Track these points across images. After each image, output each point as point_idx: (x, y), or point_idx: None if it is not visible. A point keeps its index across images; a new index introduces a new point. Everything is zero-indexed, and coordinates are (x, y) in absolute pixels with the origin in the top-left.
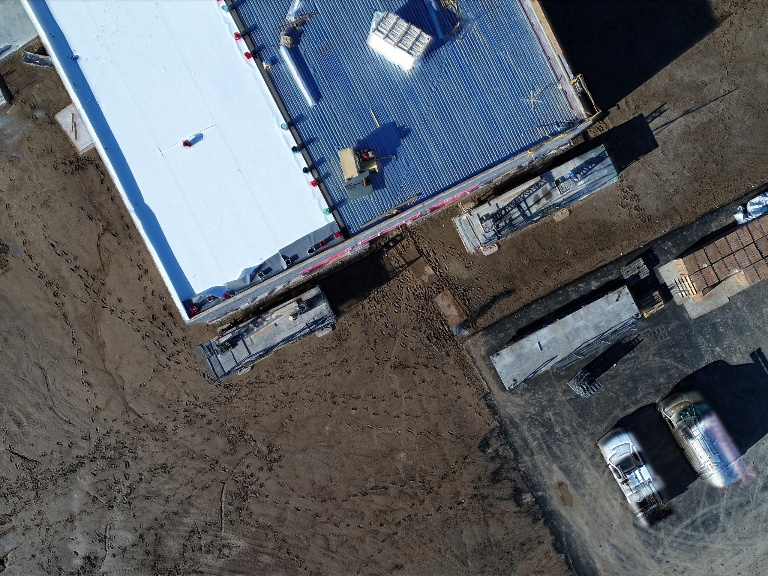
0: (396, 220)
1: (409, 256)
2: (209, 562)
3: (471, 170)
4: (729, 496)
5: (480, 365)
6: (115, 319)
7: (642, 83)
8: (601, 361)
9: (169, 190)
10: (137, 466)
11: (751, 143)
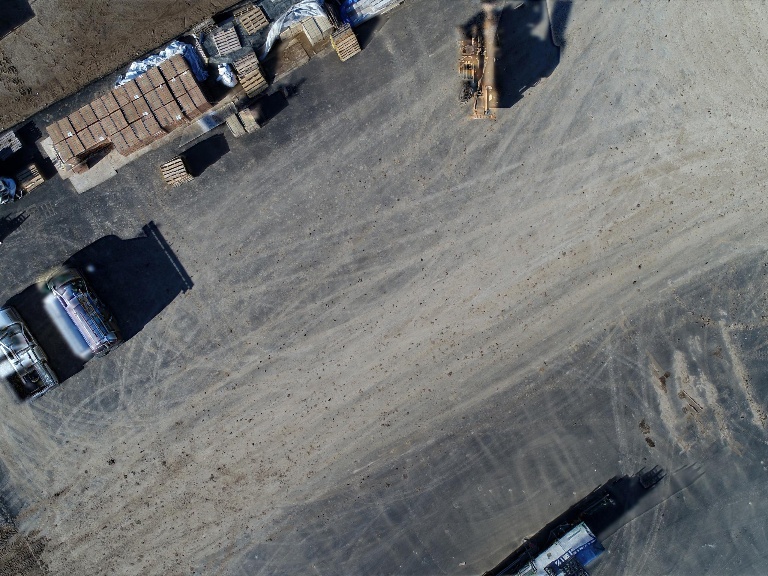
0: None
1: None
2: None
3: None
4: (128, 373)
5: None
6: None
7: None
8: None
9: None
10: None
11: (134, 9)
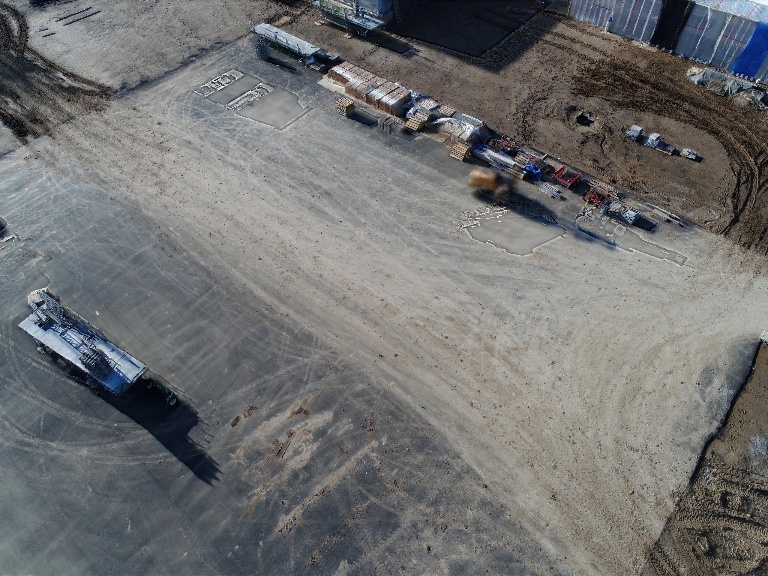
0: None
1: None
2: None
3: None
4: None
5: None
6: None
7: (429, 43)
8: None
9: None
10: None
11: None
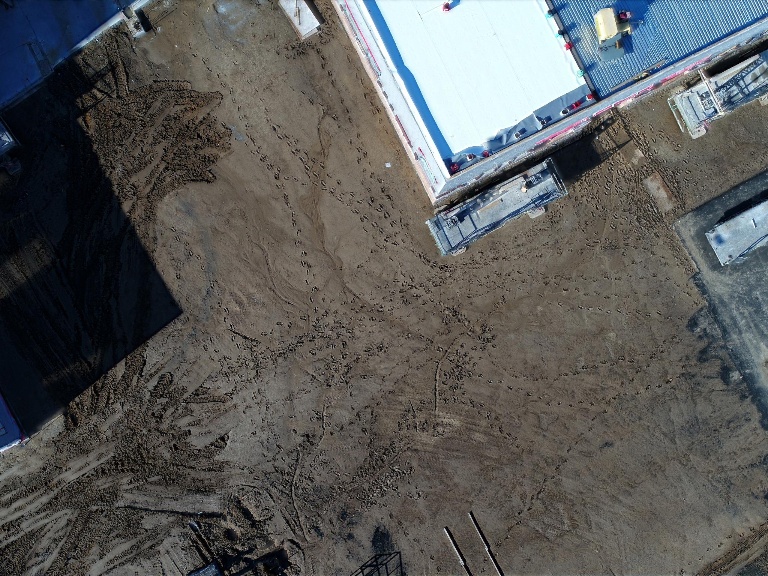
0: (647, 82)
1: (620, 139)
2: (423, 440)
3: (715, 36)
4: None
5: (689, 245)
6: (334, 201)
7: None
8: None
9: (428, 53)
10: (354, 346)
11: None
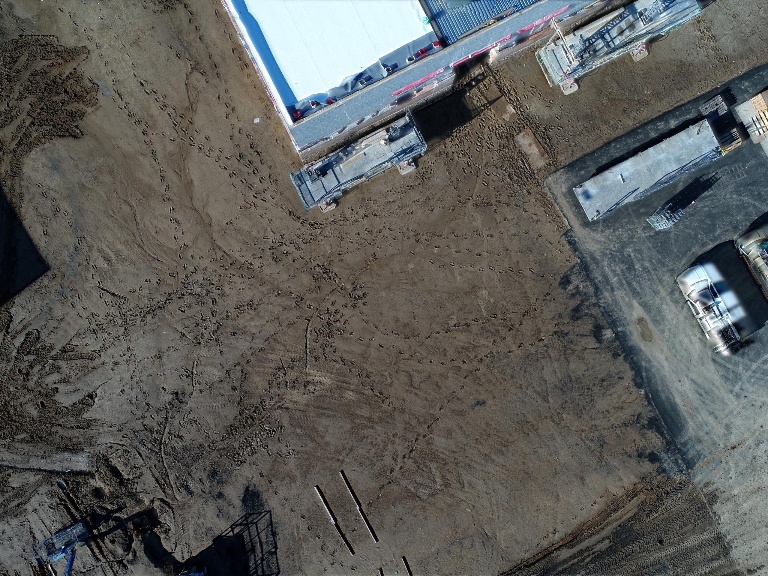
0: (494, 29)
1: (491, 95)
2: (294, 398)
3: None
4: None
5: (561, 202)
6: (203, 157)
7: None
8: (679, 199)
9: None
10: (224, 303)
11: None
